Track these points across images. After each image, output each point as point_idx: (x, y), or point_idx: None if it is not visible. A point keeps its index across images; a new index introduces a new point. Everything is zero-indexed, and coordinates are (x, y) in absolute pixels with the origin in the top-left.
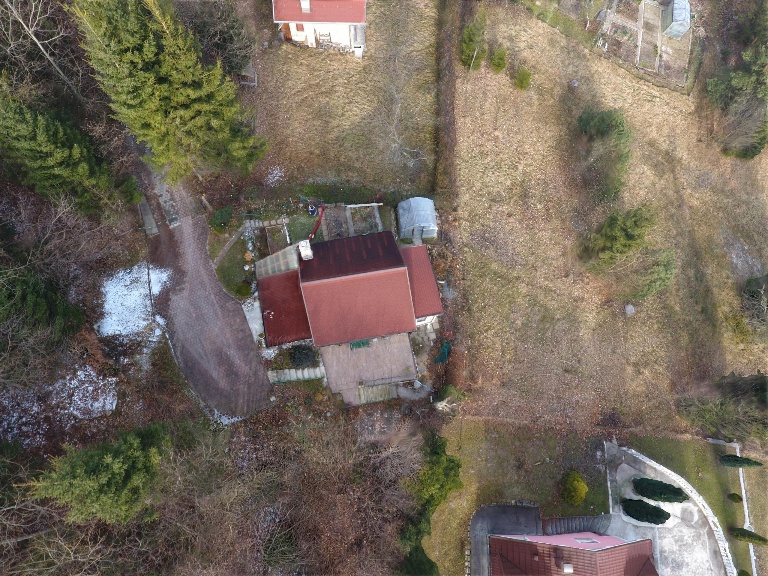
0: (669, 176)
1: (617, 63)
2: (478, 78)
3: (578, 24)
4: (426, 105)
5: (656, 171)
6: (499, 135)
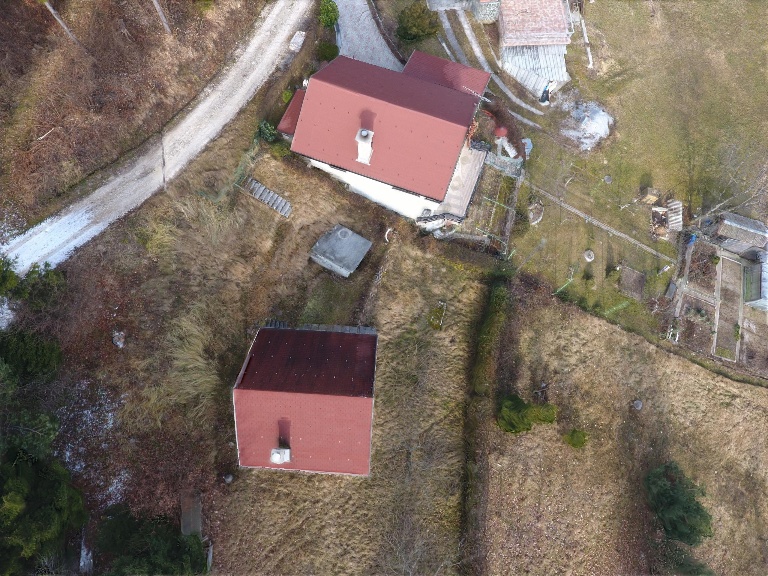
0: (750, 513)
1: (689, 356)
2: (517, 439)
3: (642, 306)
4: (449, 564)
5: (735, 509)
6: (542, 526)
